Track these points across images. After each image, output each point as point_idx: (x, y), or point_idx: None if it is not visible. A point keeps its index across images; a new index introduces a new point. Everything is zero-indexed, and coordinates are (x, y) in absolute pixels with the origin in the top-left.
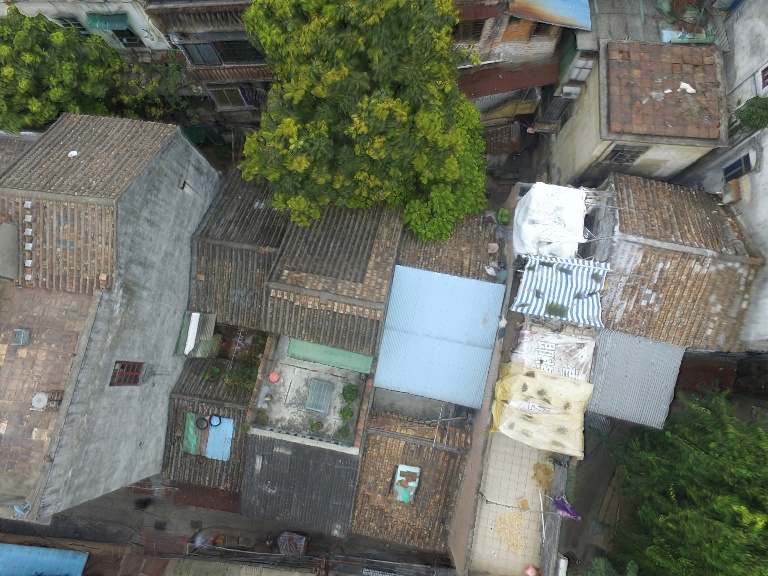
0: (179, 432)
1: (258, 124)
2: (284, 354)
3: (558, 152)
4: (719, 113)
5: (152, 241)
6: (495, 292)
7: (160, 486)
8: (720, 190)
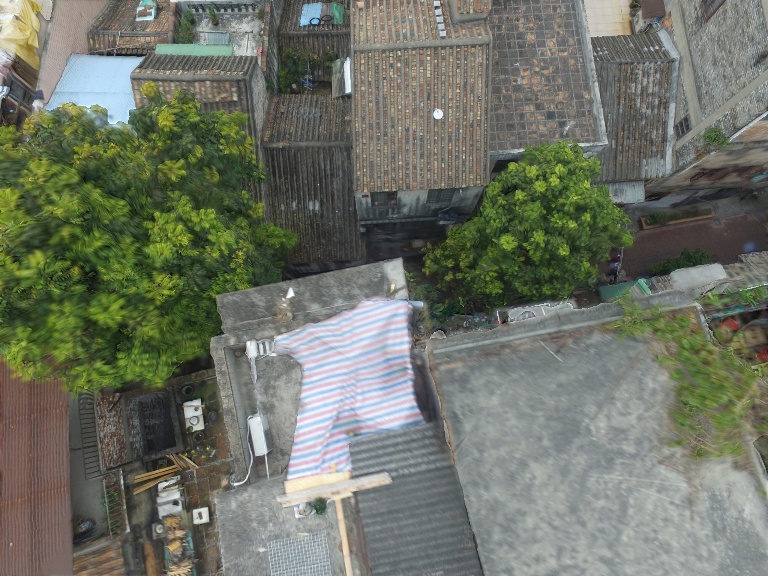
0: (348, 12)
1: None
2: None
3: None
4: None
5: None
6: None
7: None
8: None
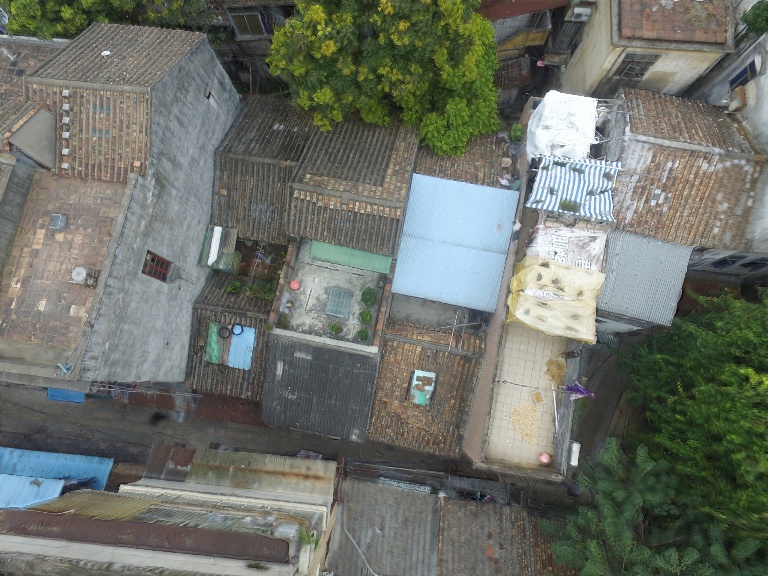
0: (202, 342)
1: None
2: (304, 264)
3: (568, 81)
4: (726, 20)
5: (181, 141)
6: (509, 199)
7: (184, 392)
8: (726, 99)
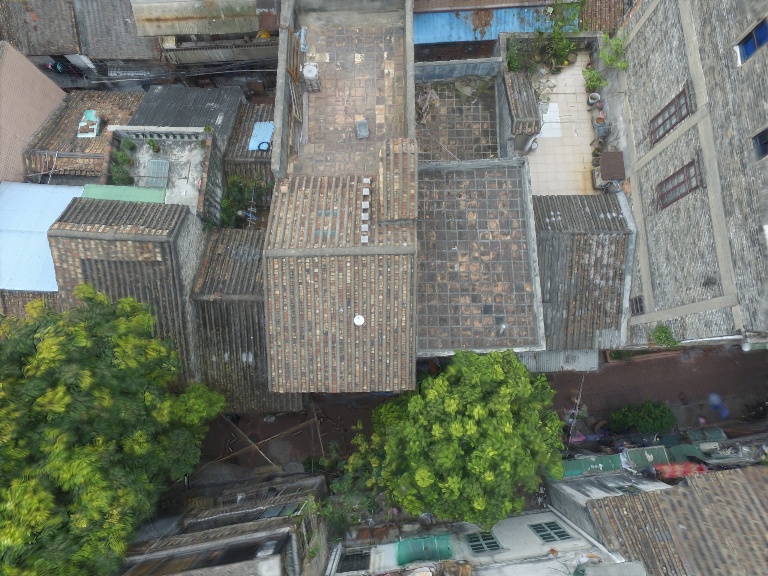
0: None
1: (286, 476)
2: None
3: None
4: None
5: None
6: None
7: None
8: None
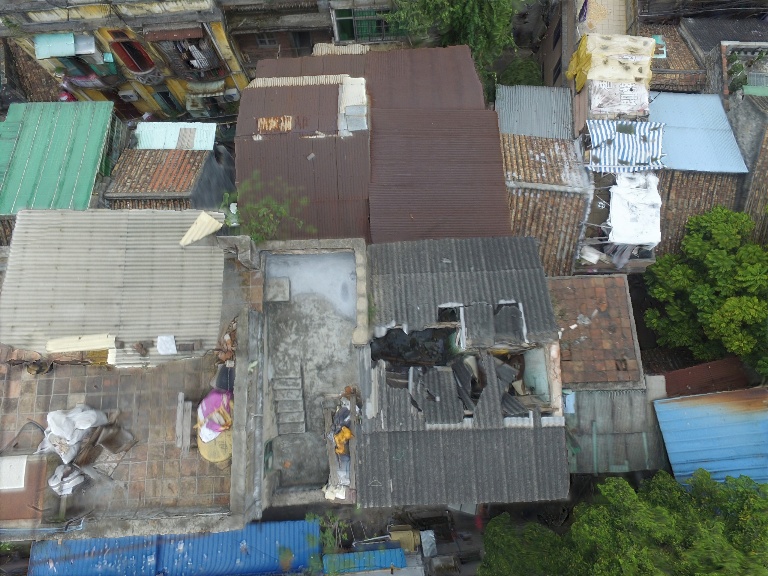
0: None
1: None
2: None
3: None
4: None
5: None
6: None
7: None
8: None
